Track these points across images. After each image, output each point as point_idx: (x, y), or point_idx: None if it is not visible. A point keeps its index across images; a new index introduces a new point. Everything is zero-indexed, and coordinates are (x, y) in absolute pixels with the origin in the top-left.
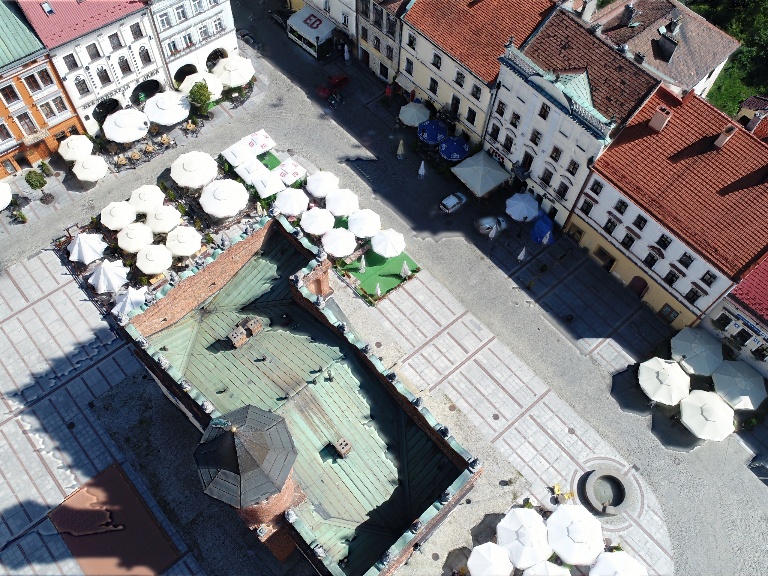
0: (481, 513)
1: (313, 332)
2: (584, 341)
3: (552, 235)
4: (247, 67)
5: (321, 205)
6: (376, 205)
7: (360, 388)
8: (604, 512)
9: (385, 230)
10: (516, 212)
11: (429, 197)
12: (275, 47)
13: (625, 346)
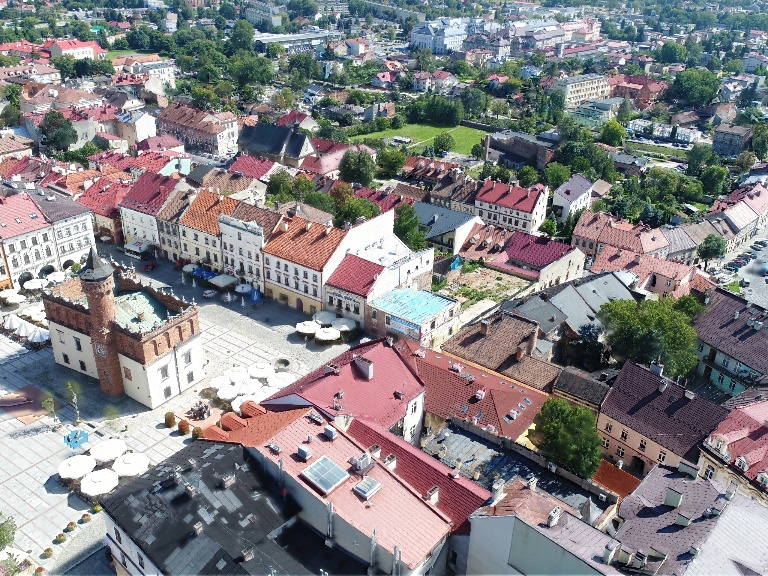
0: None
1: (129, 293)
2: (275, 327)
3: (260, 298)
4: (102, 260)
5: None
6: None
7: (149, 302)
8: (279, 369)
9: None
10: (240, 289)
11: (199, 295)
12: (118, 259)
13: (295, 326)
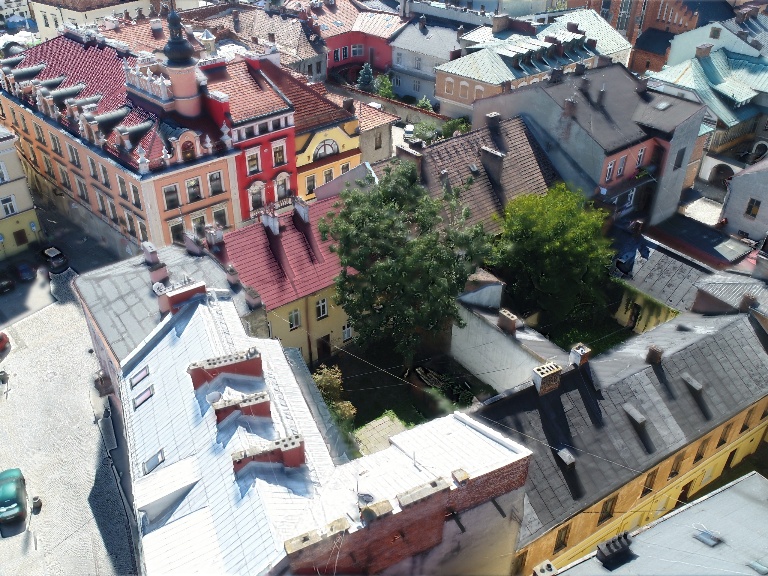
0: None
1: None
2: None
3: None
4: None
5: None
6: None
7: None
8: None
9: None
10: (19, 18)
11: None
12: None
13: None
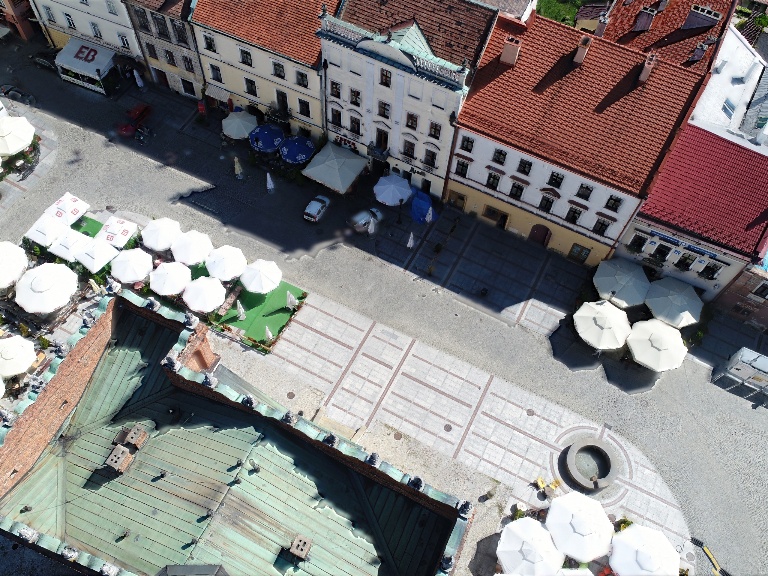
0: (472, 543)
1: (213, 418)
2: (507, 311)
3: (433, 210)
4: (23, 126)
5: (168, 258)
6: (232, 238)
7: (295, 466)
8: (597, 488)
9: (252, 263)
10: (388, 197)
11: (288, 211)
12: (50, 95)
13: (549, 302)
